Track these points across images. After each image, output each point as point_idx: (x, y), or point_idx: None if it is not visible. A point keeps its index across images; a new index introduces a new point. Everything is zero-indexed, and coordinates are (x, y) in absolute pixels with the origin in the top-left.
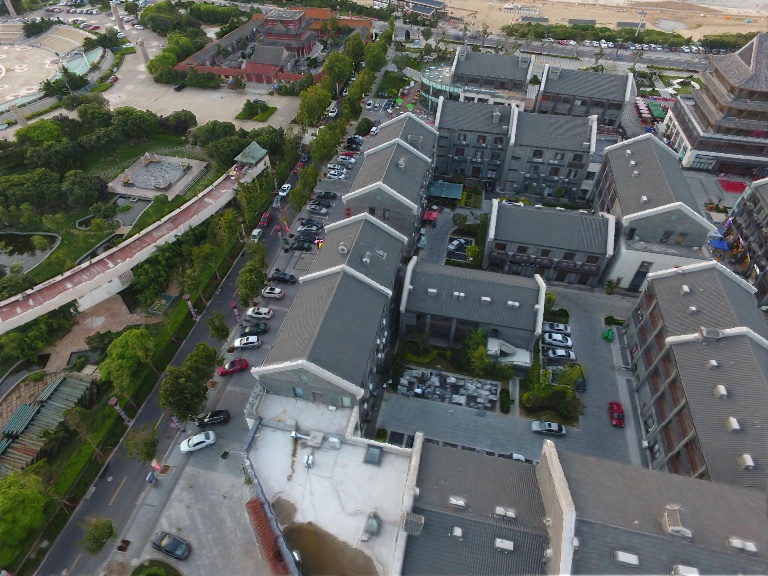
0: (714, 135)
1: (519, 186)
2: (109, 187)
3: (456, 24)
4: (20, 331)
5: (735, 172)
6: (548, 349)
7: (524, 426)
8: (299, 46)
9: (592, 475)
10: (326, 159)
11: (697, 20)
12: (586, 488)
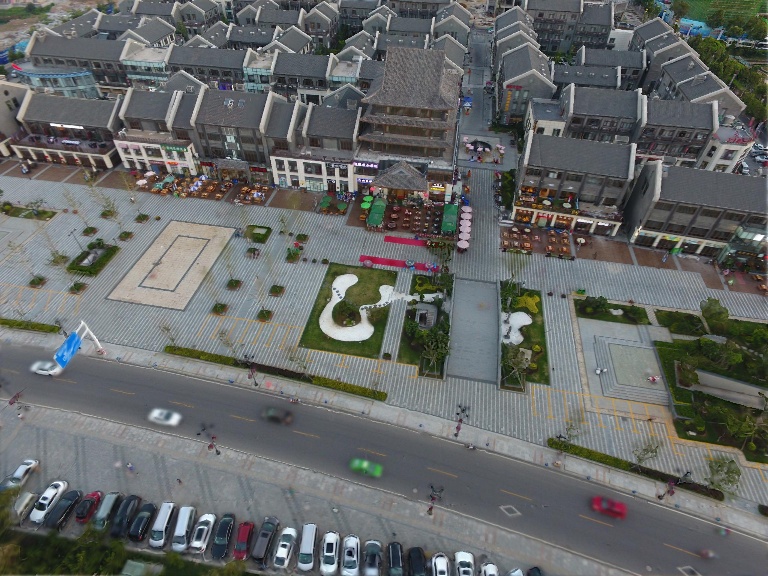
0: None
1: None
2: None
3: None
4: None
5: None
6: None
7: None
8: None
9: (572, 5)
10: None
11: None
12: (576, 1)
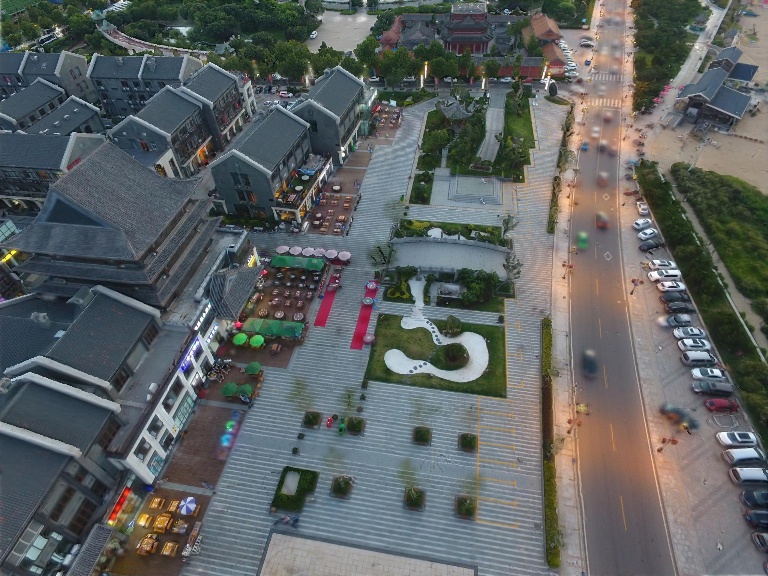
0: None
1: None
2: None
3: (683, 130)
4: None
5: None
6: None
7: None
8: None
9: None
10: None
11: None
12: None
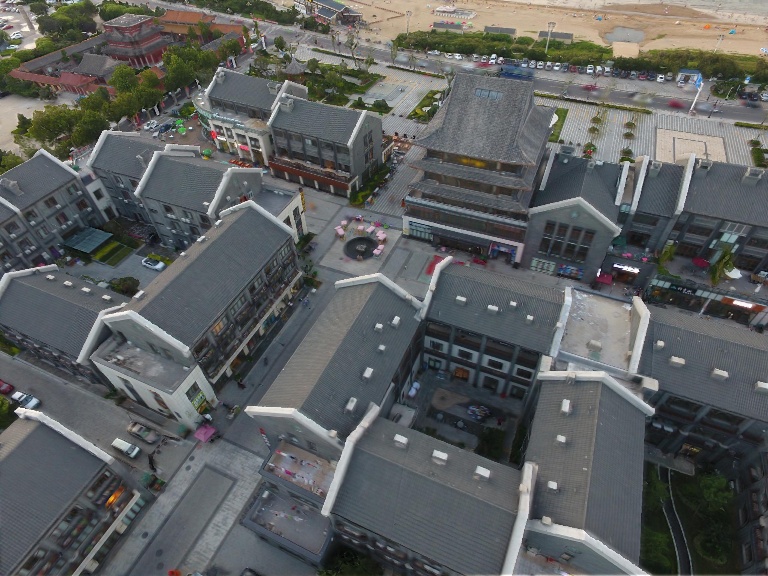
0: (419, 200)
1: (175, 242)
2: None
3: None
4: None
5: (462, 248)
6: None
7: None
8: (136, 54)
9: None
10: None
11: (664, 29)
12: None
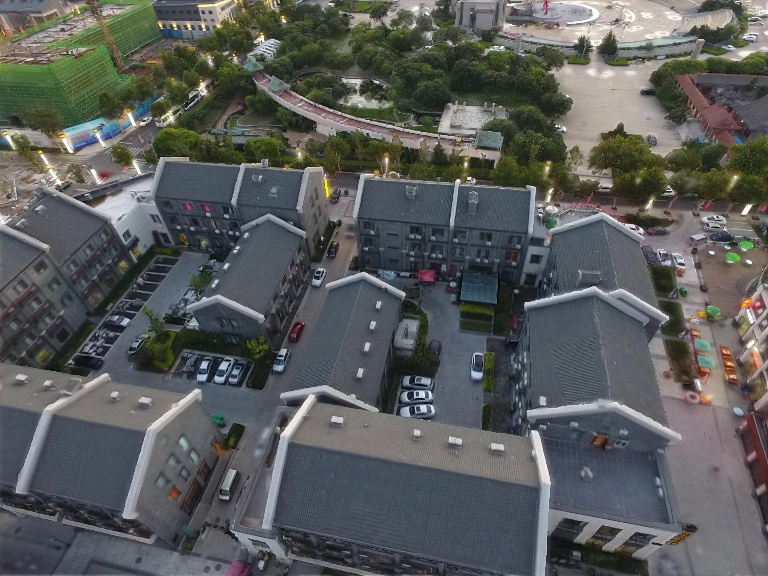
0: None
1: None
2: (449, 105)
3: None
4: (295, 115)
5: None
6: (218, 361)
7: (150, 332)
8: None
9: (7, 254)
10: (499, 183)
11: None
12: None
